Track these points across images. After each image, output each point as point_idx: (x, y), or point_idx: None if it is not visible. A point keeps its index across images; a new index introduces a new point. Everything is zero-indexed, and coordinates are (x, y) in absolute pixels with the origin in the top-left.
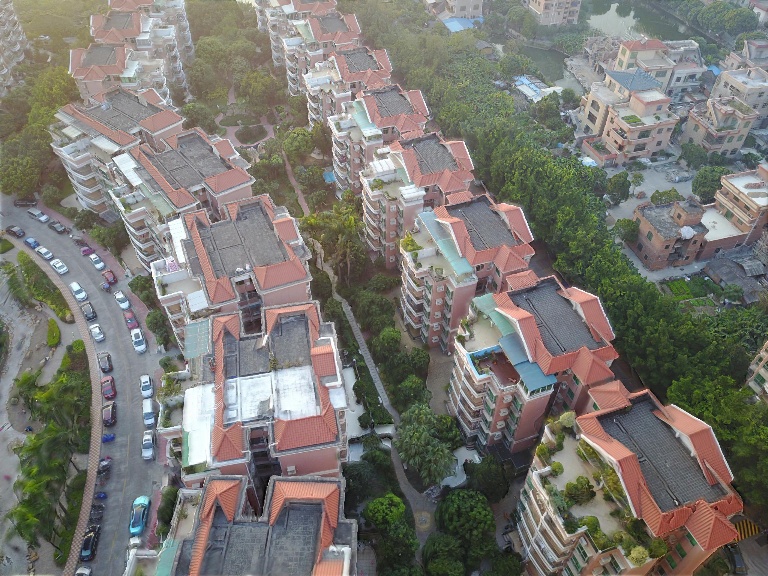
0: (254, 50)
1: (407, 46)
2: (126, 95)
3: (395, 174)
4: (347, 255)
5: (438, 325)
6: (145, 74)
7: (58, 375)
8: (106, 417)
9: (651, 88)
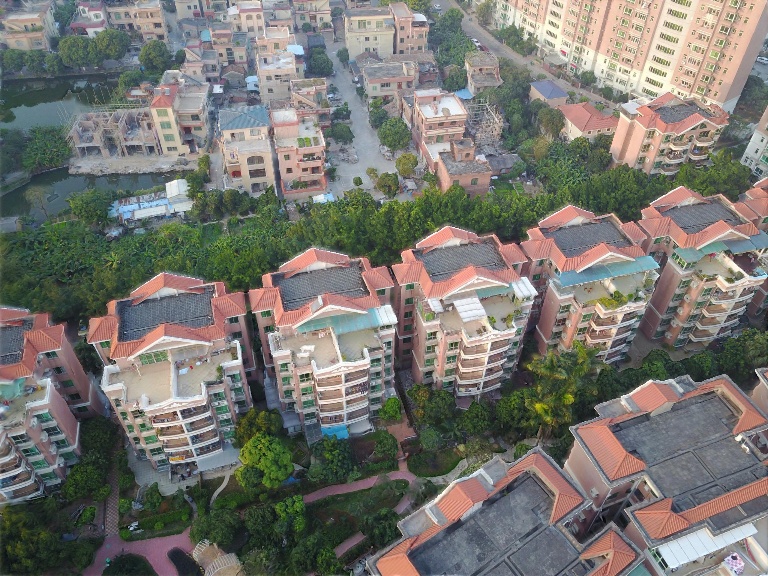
0: None
1: None
2: None
3: None
4: None
5: None
6: None
7: None
8: None
9: (268, 113)
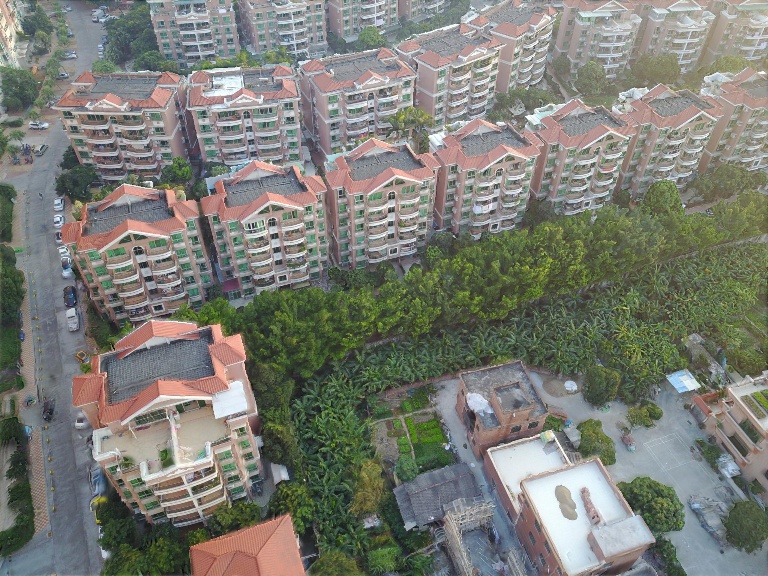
0: None
1: None
2: None
3: None
4: None
5: None
6: None
7: None
8: None
9: None
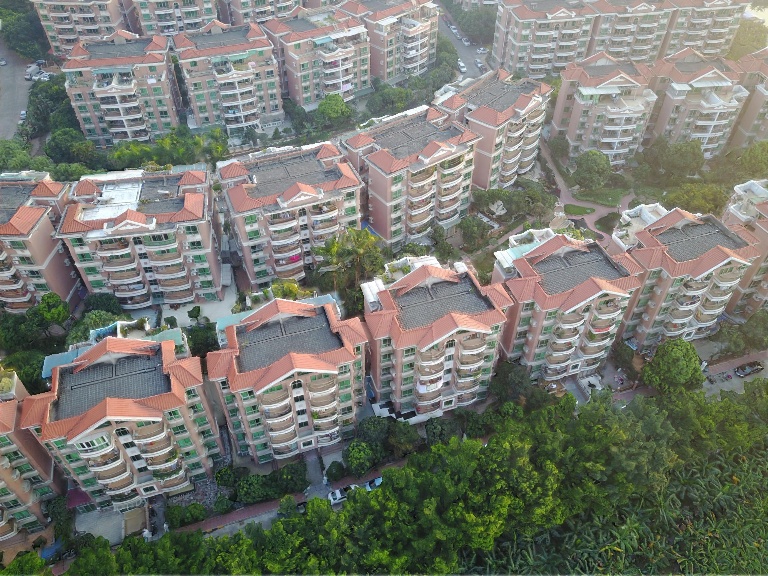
0: None
1: None
2: None
3: None
4: None
5: None
6: None
7: None
8: None
9: None
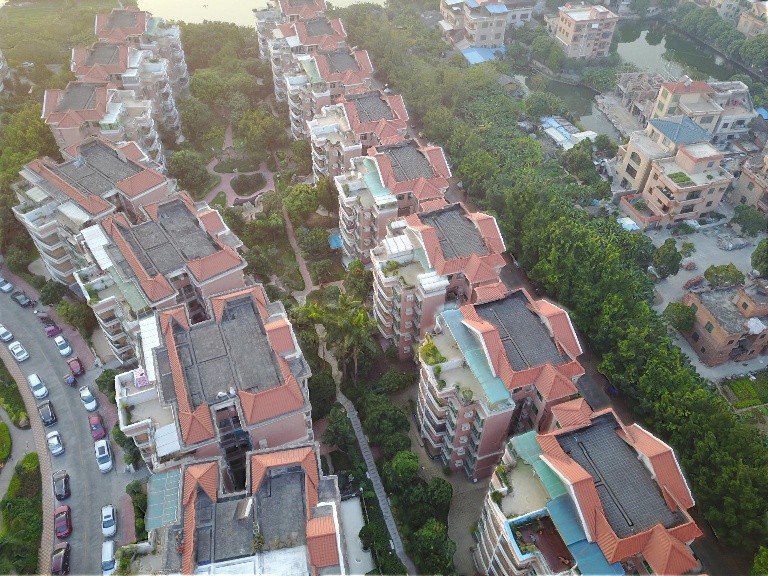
0: (255, 85)
1: (423, 83)
2: (104, 148)
3: (412, 255)
4: (354, 354)
5: (463, 449)
6: (129, 118)
7: (1, 507)
8: (56, 568)
9: (700, 141)
